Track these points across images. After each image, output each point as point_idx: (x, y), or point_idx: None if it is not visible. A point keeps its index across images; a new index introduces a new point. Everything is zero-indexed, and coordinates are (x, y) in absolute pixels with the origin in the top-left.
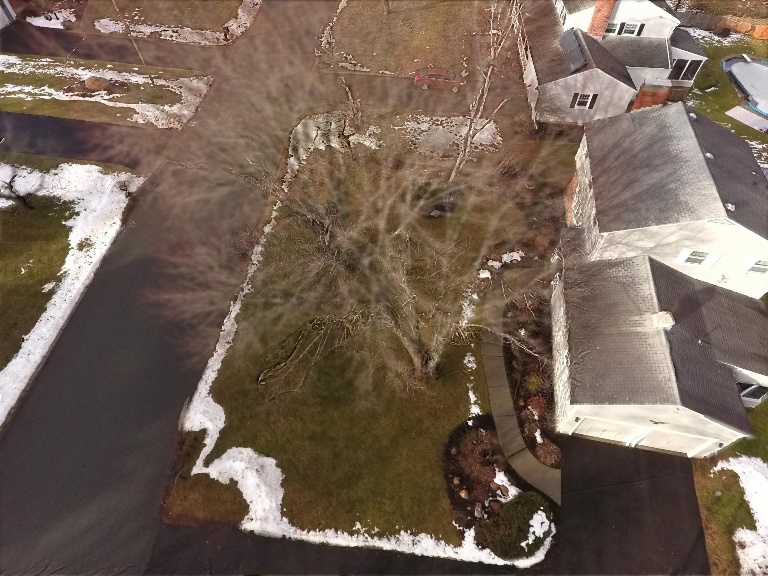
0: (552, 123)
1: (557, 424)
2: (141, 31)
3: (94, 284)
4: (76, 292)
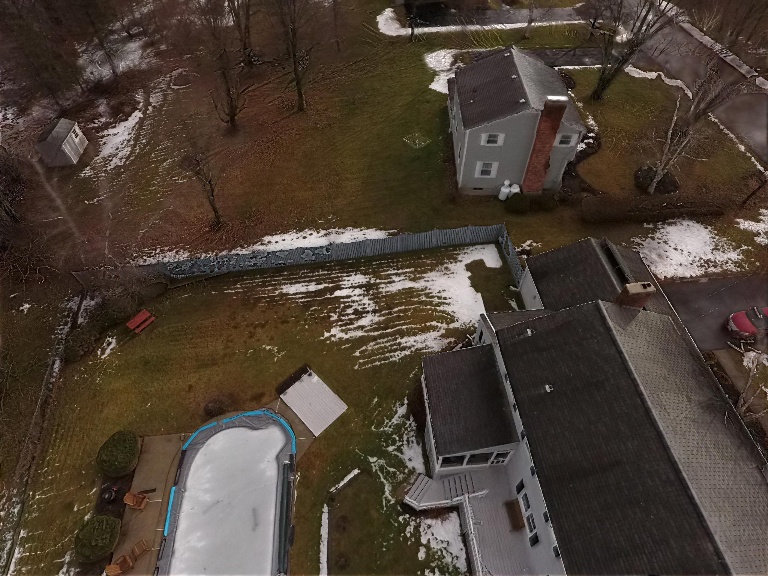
0: None
1: None
2: None
3: None
4: None
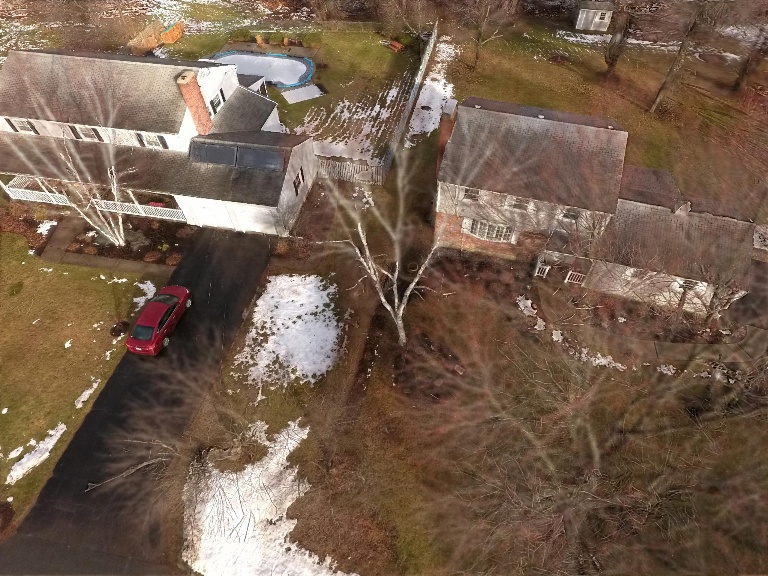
0: (295, 222)
1: (713, 316)
2: None
3: None
4: None
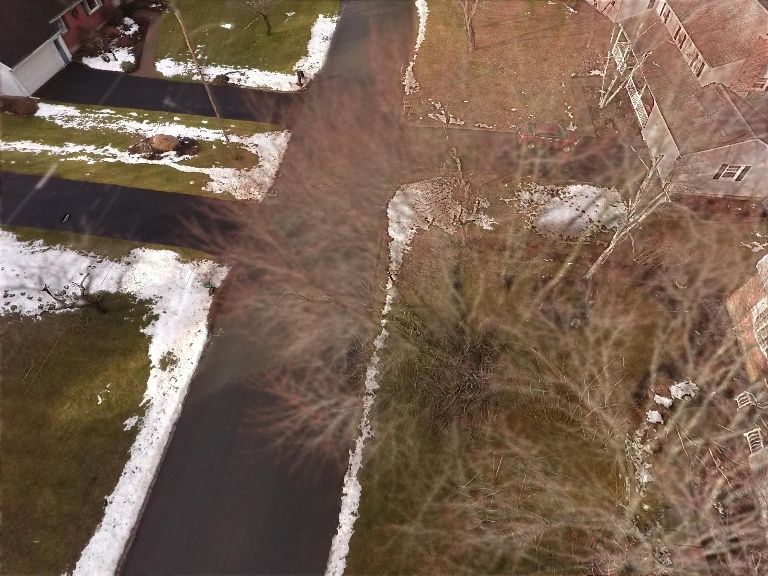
0: (687, 194)
1: None
2: (206, 73)
3: (183, 420)
4: (164, 432)
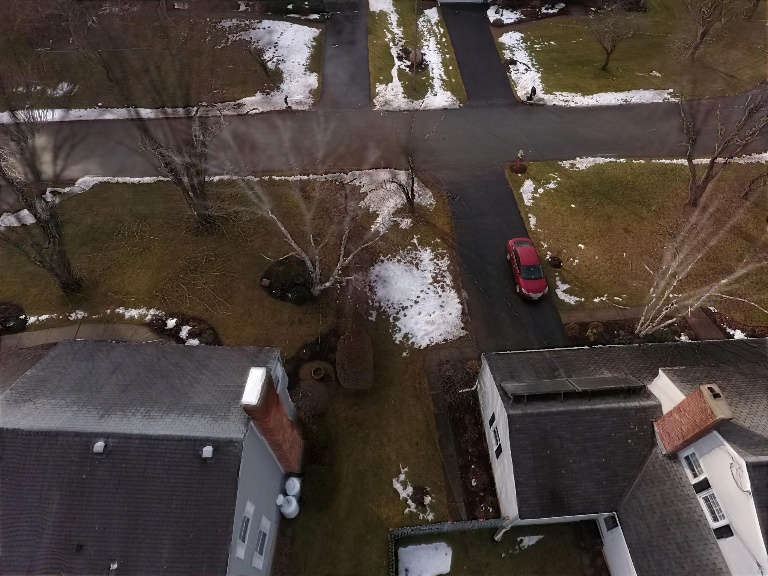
0: (481, 415)
1: None
2: (515, 54)
3: (203, 118)
4: None
